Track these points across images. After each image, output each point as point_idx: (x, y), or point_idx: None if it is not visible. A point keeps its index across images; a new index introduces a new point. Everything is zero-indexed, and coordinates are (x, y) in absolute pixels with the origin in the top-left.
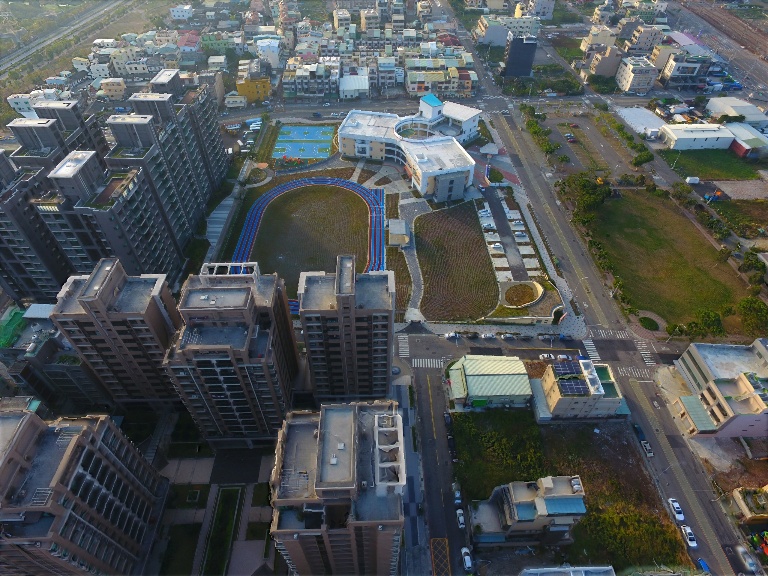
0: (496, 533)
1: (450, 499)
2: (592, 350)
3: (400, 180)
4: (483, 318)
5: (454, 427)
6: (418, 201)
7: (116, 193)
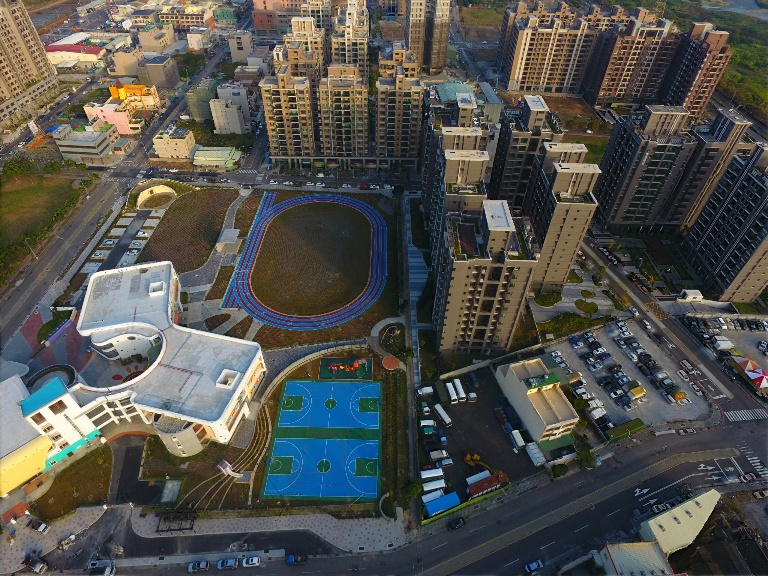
0: (247, 121)
1: (260, 136)
2: (141, 173)
3: (193, 322)
4: (198, 188)
5: (247, 148)
6: (187, 287)
7: (432, 109)
